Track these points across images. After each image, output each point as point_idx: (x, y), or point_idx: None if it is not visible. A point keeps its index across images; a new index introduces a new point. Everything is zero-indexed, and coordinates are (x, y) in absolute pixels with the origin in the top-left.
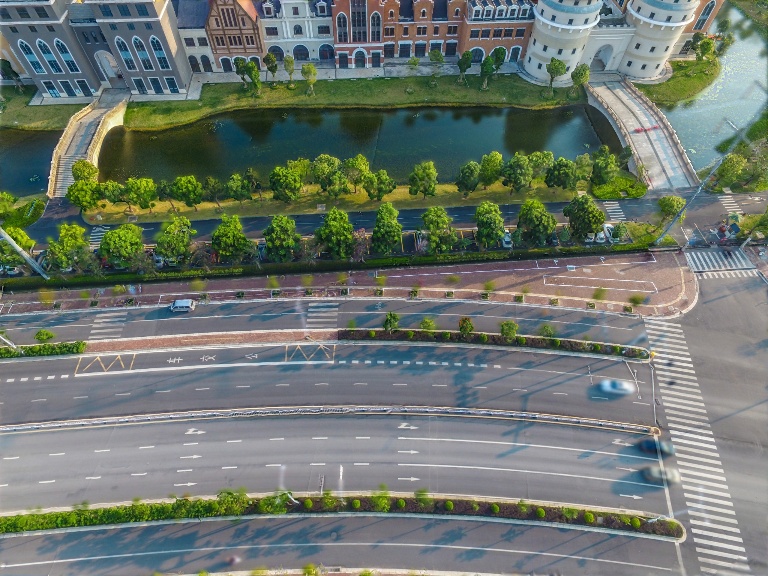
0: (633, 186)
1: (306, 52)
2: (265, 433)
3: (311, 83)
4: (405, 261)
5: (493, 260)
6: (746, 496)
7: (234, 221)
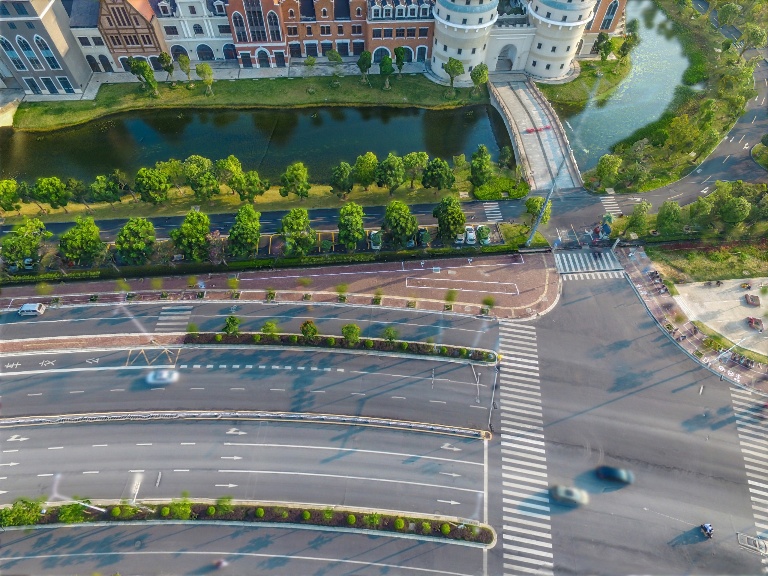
0: (515, 187)
1: (210, 52)
2: (89, 439)
3: (208, 83)
4: (268, 263)
5: (359, 262)
6: (564, 501)
7: (88, 223)
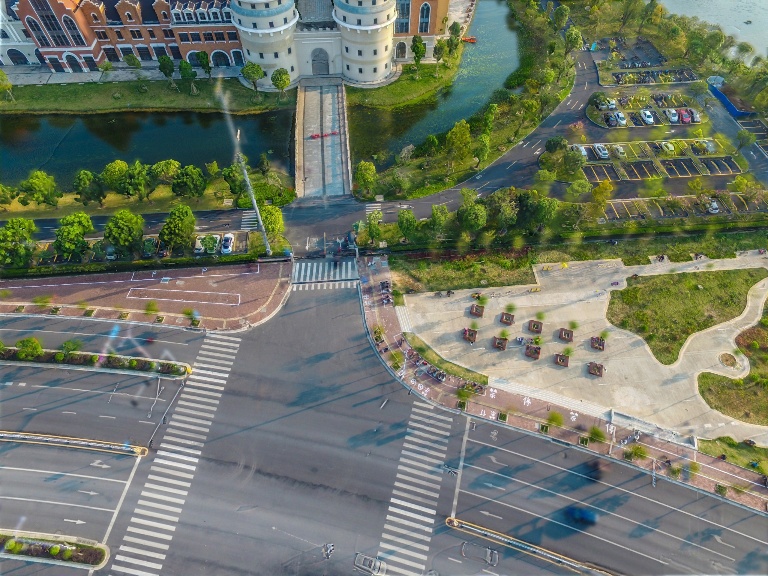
0: (281, 194)
1: (23, 56)
2: None
3: (4, 88)
4: None
5: (88, 272)
6: (193, 520)
7: None
